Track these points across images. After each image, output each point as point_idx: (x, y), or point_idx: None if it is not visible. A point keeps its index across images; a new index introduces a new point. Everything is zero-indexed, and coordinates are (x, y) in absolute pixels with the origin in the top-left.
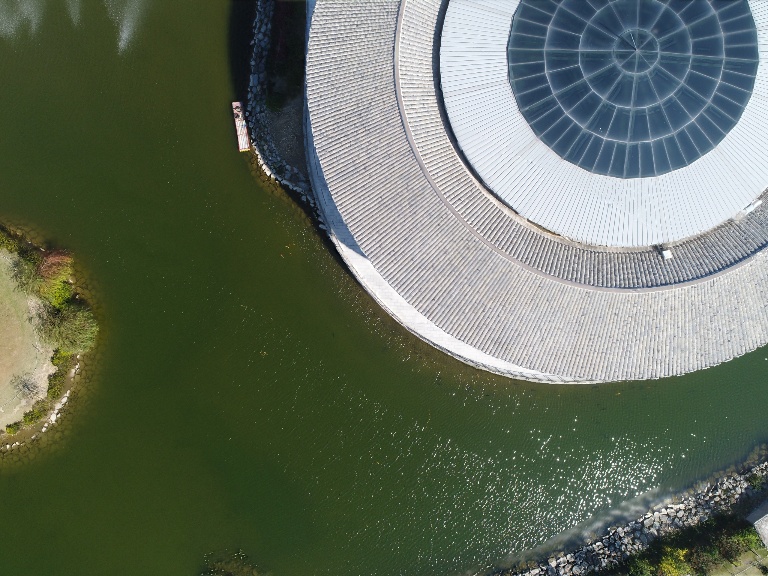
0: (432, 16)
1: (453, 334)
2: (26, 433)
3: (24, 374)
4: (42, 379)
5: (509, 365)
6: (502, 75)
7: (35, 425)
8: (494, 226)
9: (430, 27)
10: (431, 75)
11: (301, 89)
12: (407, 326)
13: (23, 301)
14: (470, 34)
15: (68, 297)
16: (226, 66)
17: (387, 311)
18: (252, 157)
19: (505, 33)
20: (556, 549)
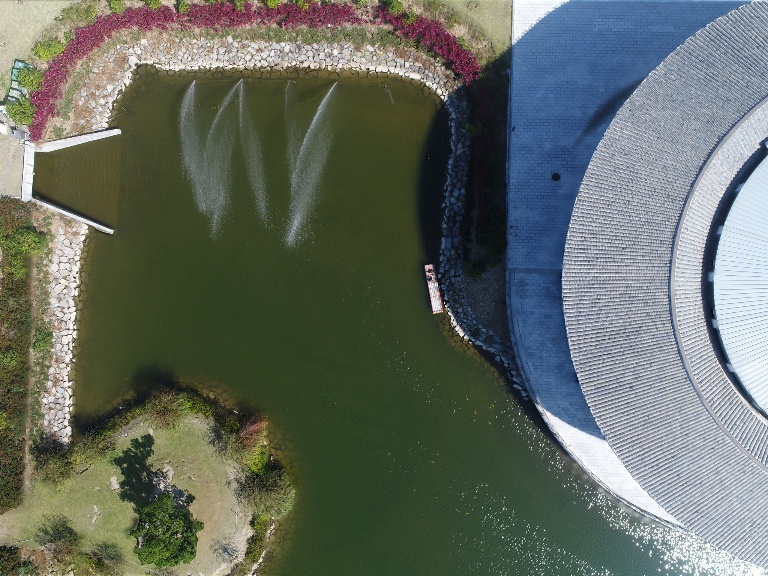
0: (701, 241)
1: (714, 543)
2: None
3: (224, 538)
4: (241, 543)
5: None
6: None
7: None
8: None
9: (699, 252)
10: (700, 298)
11: (502, 258)
12: (614, 493)
13: (221, 466)
14: (745, 263)
15: (266, 461)
16: (416, 228)
17: (594, 478)
18: (444, 318)
19: None
20: None
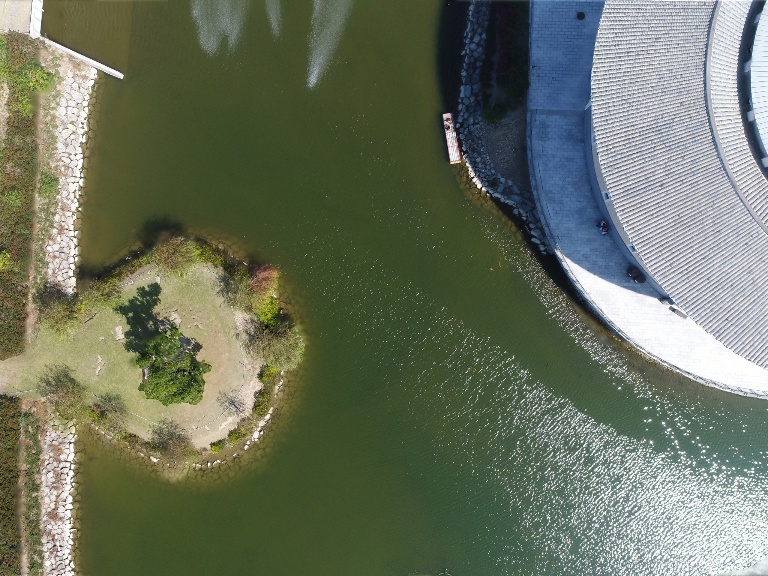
0: (738, 29)
1: (743, 355)
2: (227, 451)
3: (231, 391)
4: (249, 396)
5: (740, 382)
6: None
7: None
8: None
9: (736, 41)
10: (736, 90)
11: (523, 101)
12: (634, 342)
13: (230, 317)
14: None
15: (275, 312)
16: (435, 77)
17: (614, 327)
18: (461, 169)
19: None
20: None
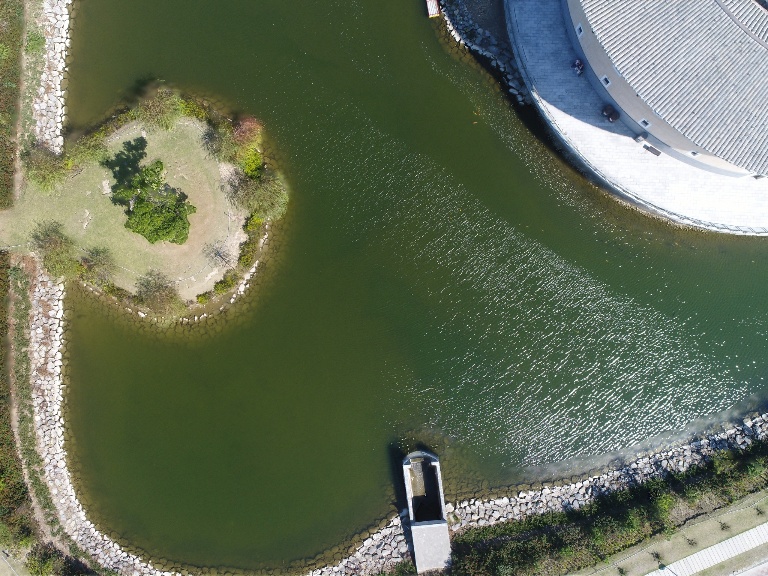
0: None
1: (710, 149)
2: (214, 305)
3: (216, 242)
4: (234, 247)
5: (713, 218)
6: None
7: (223, 296)
8: (765, 29)
9: None
10: None
11: None
12: (610, 181)
13: (215, 169)
14: None
15: (259, 164)
16: None
17: (590, 166)
18: (440, 24)
19: None
20: (750, 410)
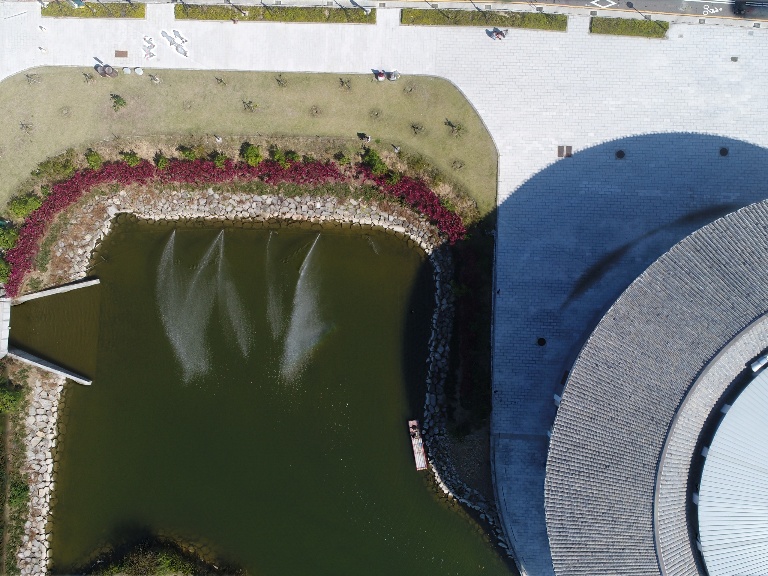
0: (686, 463)
1: None
2: None
3: None
4: None
5: None
6: (764, 533)
7: None
8: None
9: (684, 474)
10: (684, 520)
11: (486, 421)
12: None
13: None
14: (730, 490)
15: None
16: (400, 382)
17: None
18: (428, 473)
19: (767, 491)
20: None
